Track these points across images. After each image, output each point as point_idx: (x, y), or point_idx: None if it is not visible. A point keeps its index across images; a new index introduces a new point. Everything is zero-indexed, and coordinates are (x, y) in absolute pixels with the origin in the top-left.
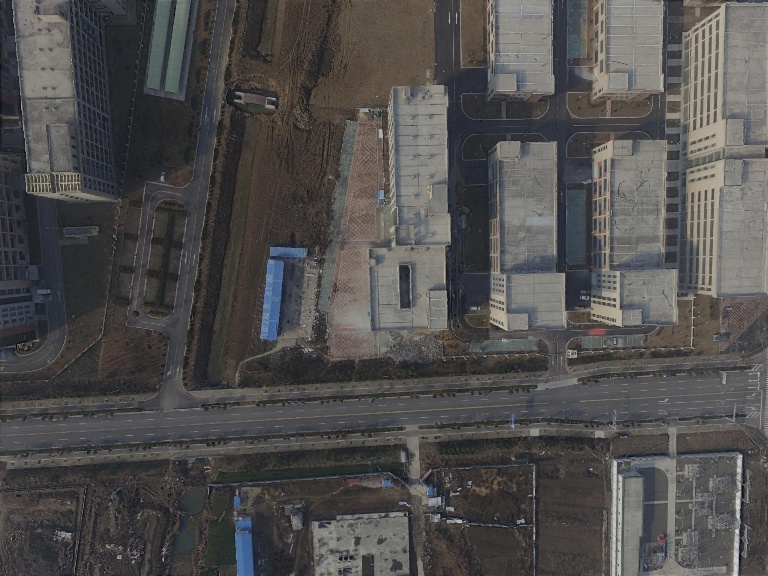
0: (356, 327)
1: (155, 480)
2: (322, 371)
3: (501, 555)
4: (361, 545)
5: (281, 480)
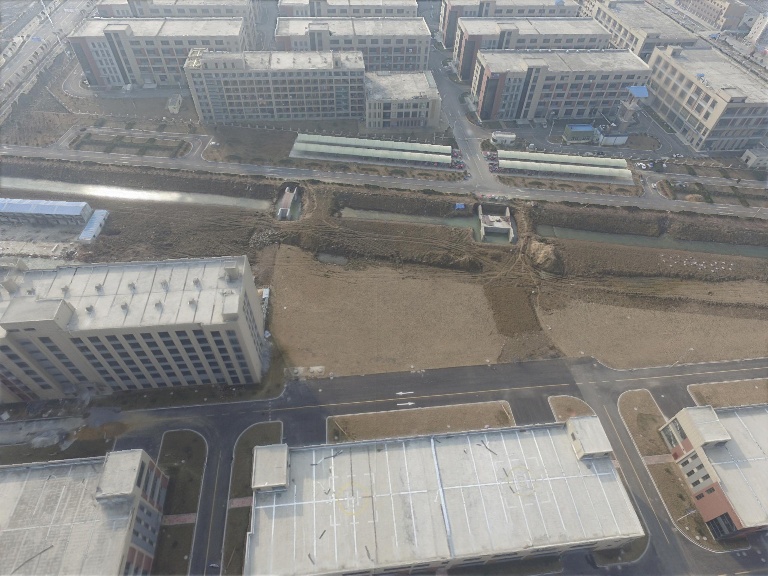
0: None
1: None
2: None
3: None
4: None
5: None
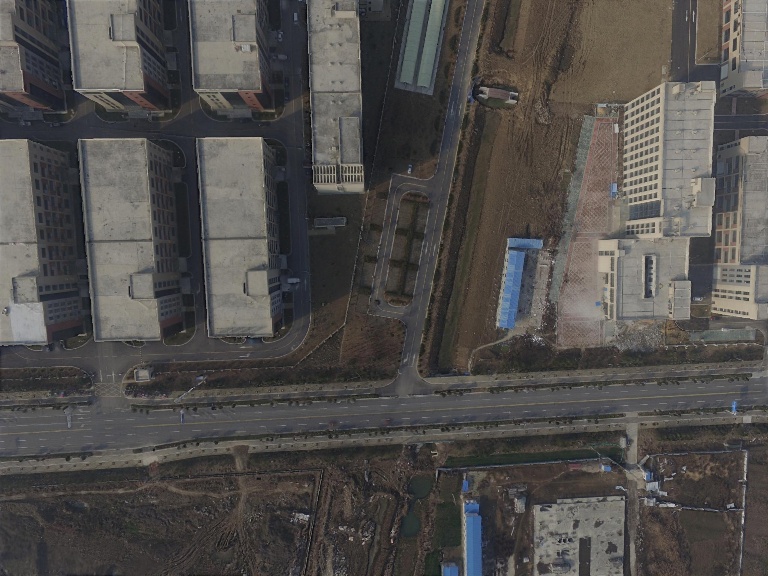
0: (584, 316)
1: (387, 464)
2: (550, 359)
3: (709, 538)
4: (579, 528)
5: (507, 465)
